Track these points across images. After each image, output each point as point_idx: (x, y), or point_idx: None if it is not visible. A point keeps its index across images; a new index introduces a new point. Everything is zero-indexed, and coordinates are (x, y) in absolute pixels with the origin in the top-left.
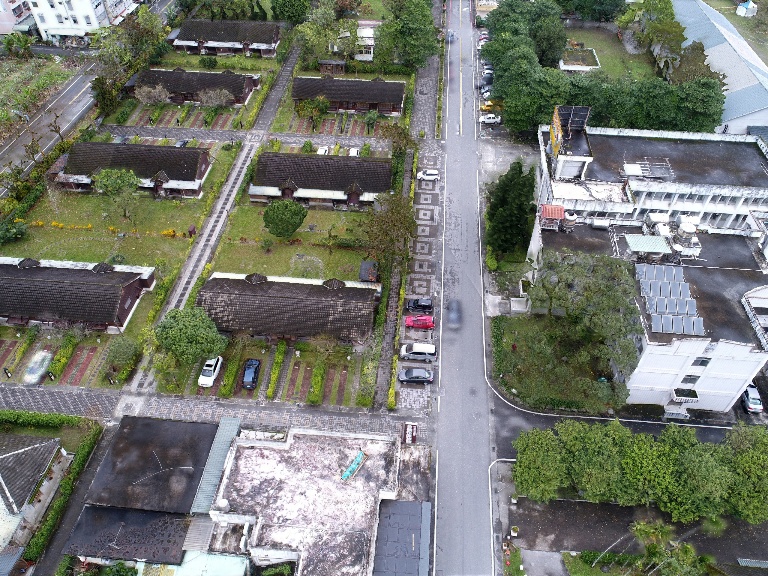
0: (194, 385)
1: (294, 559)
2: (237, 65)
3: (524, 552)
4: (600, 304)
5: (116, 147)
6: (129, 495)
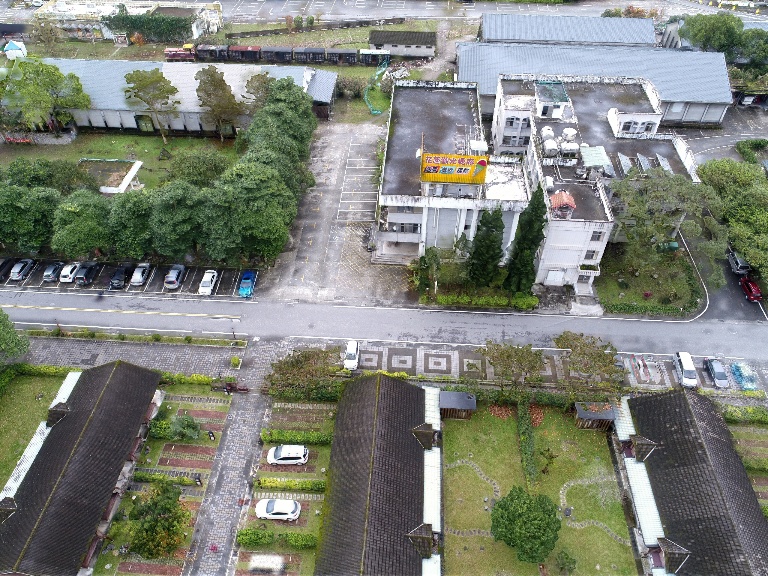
0: None
1: None
2: None
3: None
4: None
5: None
6: None
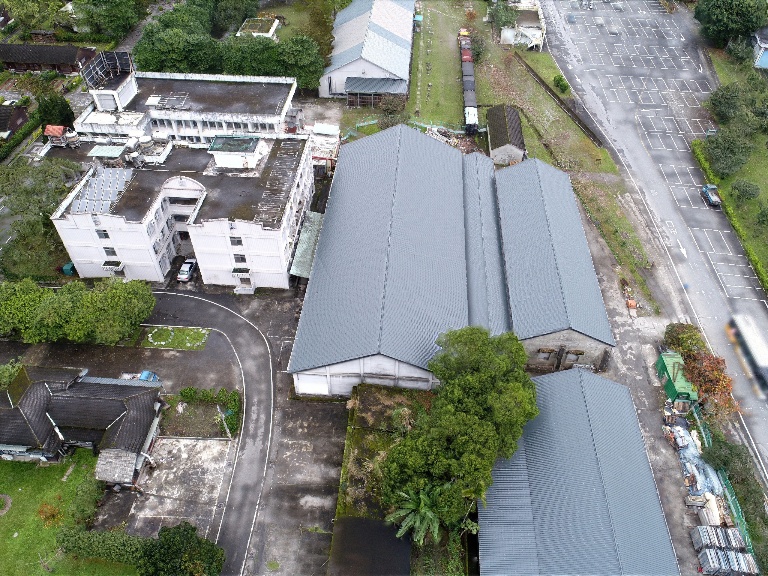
0: None
1: None
2: None
3: None
4: None
5: None
6: None
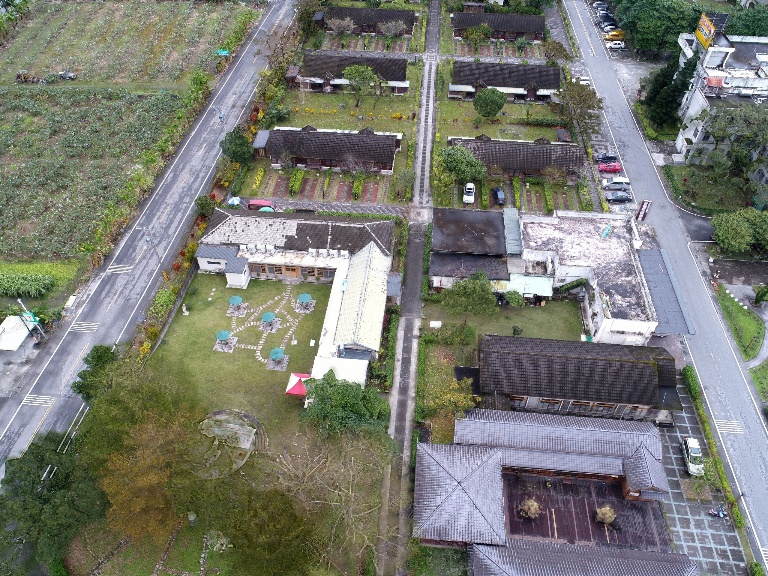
0: (459, 203)
1: (585, 276)
2: (394, 7)
3: (726, 285)
4: (767, 128)
5: (340, 57)
6: (461, 246)
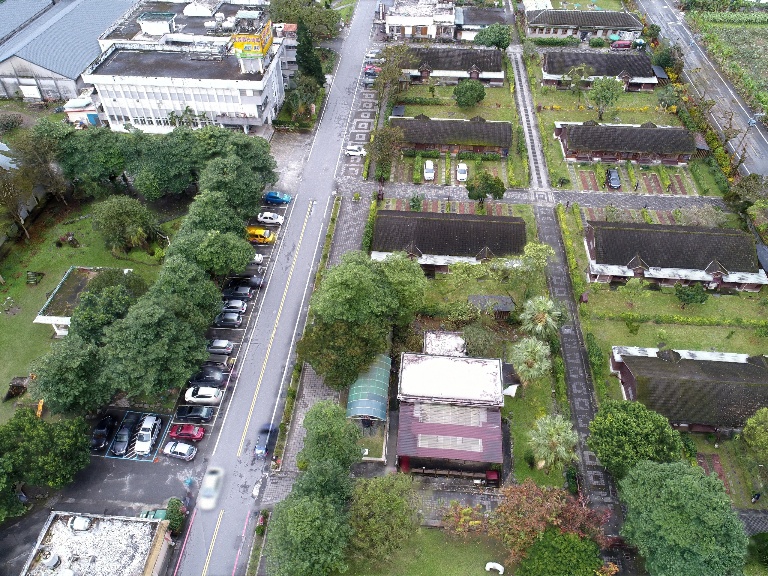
0: None
1: None
2: (651, 316)
3: None
4: None
5: (649, 128)
6: (488, 12)
